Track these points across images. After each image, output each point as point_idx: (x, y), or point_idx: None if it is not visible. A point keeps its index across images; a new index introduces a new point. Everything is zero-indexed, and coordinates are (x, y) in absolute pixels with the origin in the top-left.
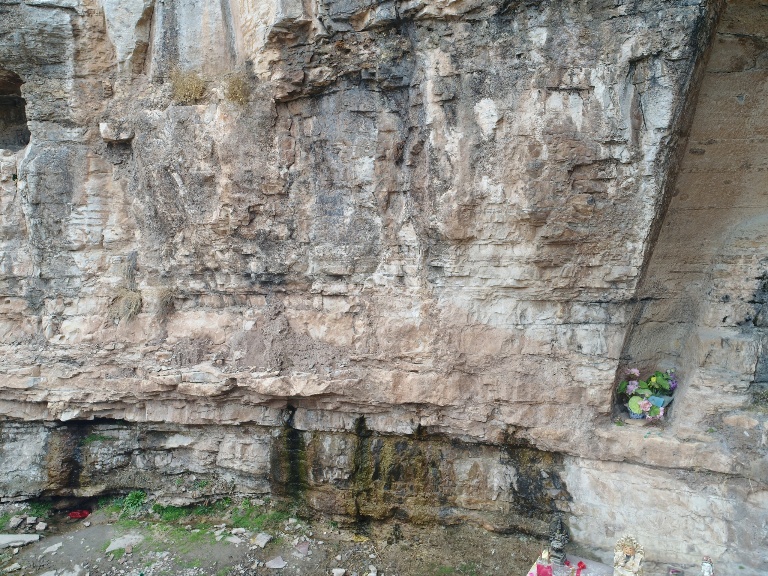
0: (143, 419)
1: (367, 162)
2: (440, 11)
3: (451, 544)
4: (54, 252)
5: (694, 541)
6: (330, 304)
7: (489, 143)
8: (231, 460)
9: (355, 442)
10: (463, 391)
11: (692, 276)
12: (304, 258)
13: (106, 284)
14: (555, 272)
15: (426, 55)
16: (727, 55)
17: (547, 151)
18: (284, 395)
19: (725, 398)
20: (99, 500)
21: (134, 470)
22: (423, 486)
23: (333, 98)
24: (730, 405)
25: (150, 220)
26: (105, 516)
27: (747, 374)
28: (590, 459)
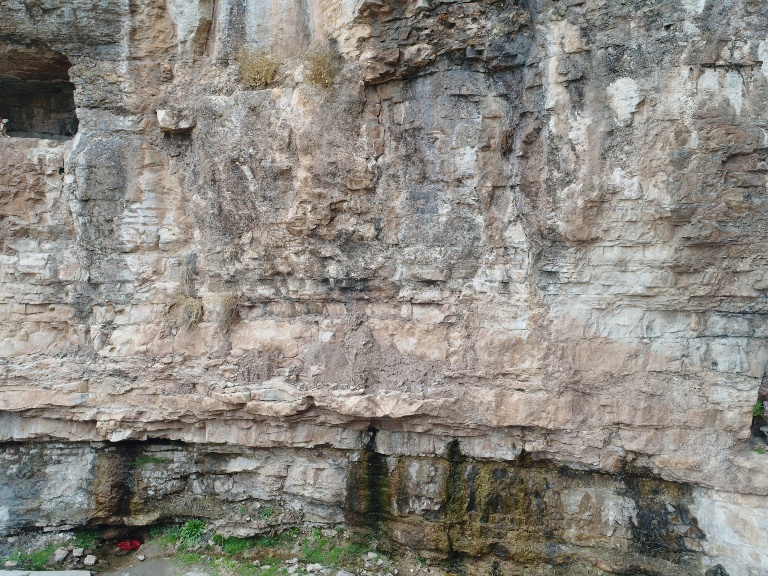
0: (203, 440)
1: (469, 153)
2: None
3: None
4: (104, 254)
5: None
6: (421, 313)
7: (624, 129)
8: (301, 486)
9: (447, 468)
10: (576, 413)
11: None
12: (392, 261)
13: (162, 290)
14: (693, 278)
15: (548, 29)
16: None
17: (697, 138)
18: (370, 416)
19: None
20: (151, 529)
21: (191, 496)
22: (526, 519)
23: (429, 80)
24: None
25: (213, 218)
26: (160, 548)
27: None
28: (727, 492)
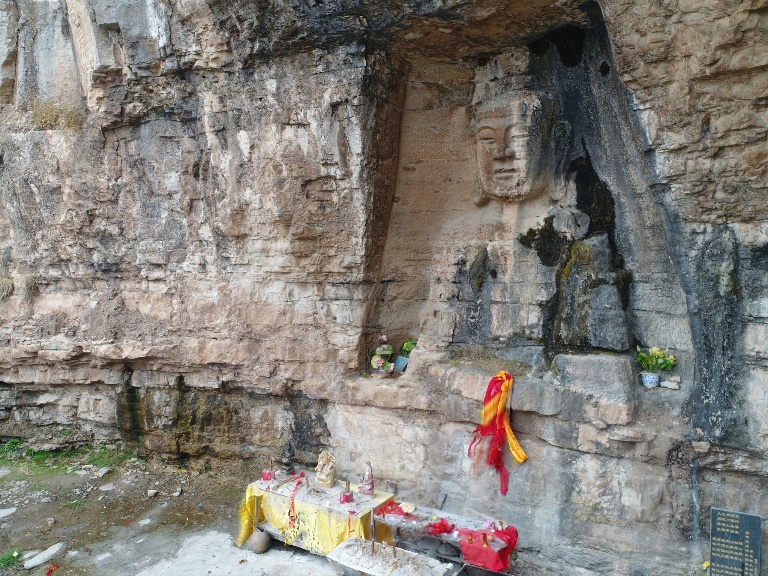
0: (17, 381)
1: (174, 176)
2: (207, 64)
3: (244, 472)
4: None
5: (404, 461)
6: (154, 287)
7: (248, 163)
8: (87, 413)
9: (177, 396)
10: (252, 353)
11: (425, 263)
12: (133, 251)
13: None
14: (307, 260)
15: (204, 96)
16: (420, 97)
17: (286, 170)
18: (117, 358)
19: (430, 355)
20: None
21: (13, 423)
22: (228, 429)
23: (148, 126)
24: (432, 360)
25: (18, 221)
26: None
27: (446, 336)
28: (343, 404)
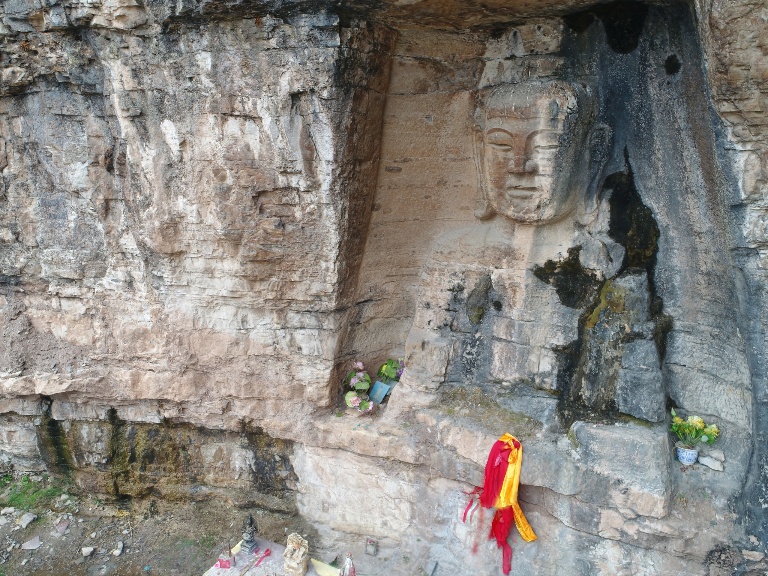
0: None
1: (79, 168)
2: (110, 22)
3: (197, 518)
4: None
5: (387, 518)
6: (67, 305)
7: (179, 164)
8: (1, 444)
9: (110, 430)
10: (199, 387)
11: (410, 278)
12: (35, 261)
13: None
14: (263, 285)
15: (110, 65)
16: (410, 77)
17: (231, 176)
18: (28, 394)
19: (418, 397)
20: None
21: None
22: (175, 468)
23: (37, 98)
24: (420, 404)
25: None
26: None
27: (437, 376)
28: (312, 446)
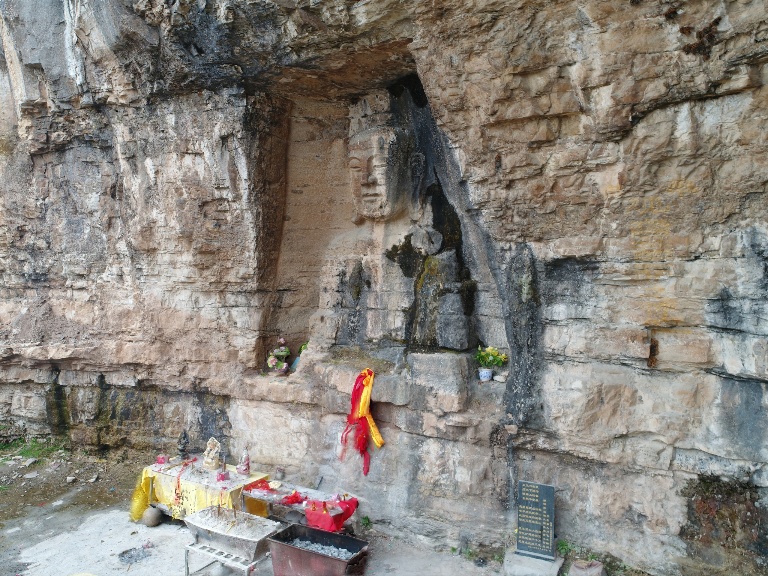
0: None
1: (94, 196)
2: (118, 100)
3: (156, 461)
4: None
5: (291, 449)
6: (78, 295)
7: (154, 186)
8: (20, 409)
9: (99, 393)
10: (164, 355)
11: (317, 274)
12: (59, 263)
13: None
14: (208, 272)
15: (117, 127)
16: (303, 130)
17: (186, 192)
18: (43, 359)
19: (315, 355)
20: None
21: None
22: (143, 423)
23: (72, 152)
24: (316, 359)
25: None
26: None
27: (329, 339)
28: (242, 399)
